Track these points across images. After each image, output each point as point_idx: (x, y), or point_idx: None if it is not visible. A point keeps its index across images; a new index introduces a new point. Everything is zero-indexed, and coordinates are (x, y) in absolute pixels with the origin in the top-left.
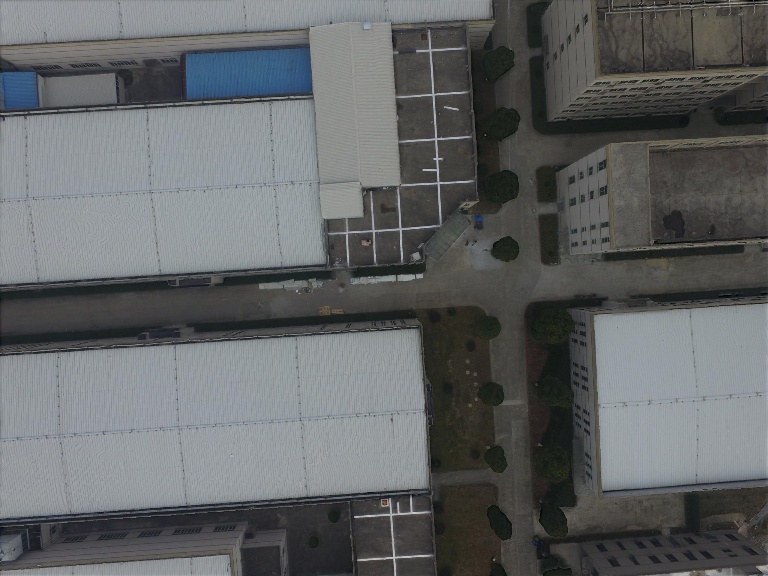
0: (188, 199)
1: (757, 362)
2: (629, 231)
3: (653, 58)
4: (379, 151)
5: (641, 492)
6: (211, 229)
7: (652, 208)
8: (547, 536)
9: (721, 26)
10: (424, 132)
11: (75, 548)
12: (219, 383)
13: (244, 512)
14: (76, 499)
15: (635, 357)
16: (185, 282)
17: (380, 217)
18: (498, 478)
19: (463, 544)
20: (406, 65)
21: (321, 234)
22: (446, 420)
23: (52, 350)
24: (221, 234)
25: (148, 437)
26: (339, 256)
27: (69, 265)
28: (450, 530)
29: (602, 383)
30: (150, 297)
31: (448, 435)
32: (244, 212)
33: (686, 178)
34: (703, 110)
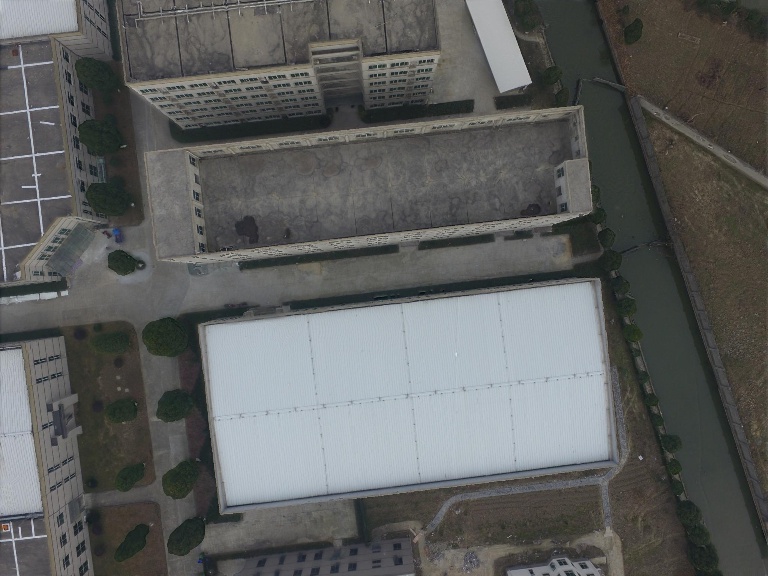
0: None
1: (379, 366)
2: (173, 241)
3: (191, 62)
4: None
5: (266, 505)
6: None
7: (223, 215)
8: (214, 553)
9: (260, 26)
10: (21, 149)
11: None
12: None
13: None
14: None
15: (251, 367)
16: None
17: None
18: (159, 495)
19: (125, 565)
20: None
21: None
22: (99, 438)
23: None
24: None
25: None
26: None
27: None
28: (112, 551)
29: (217, 395)
30: None
31: (102, 454)
32: None
33: (256, 182)
34: (345, 109)
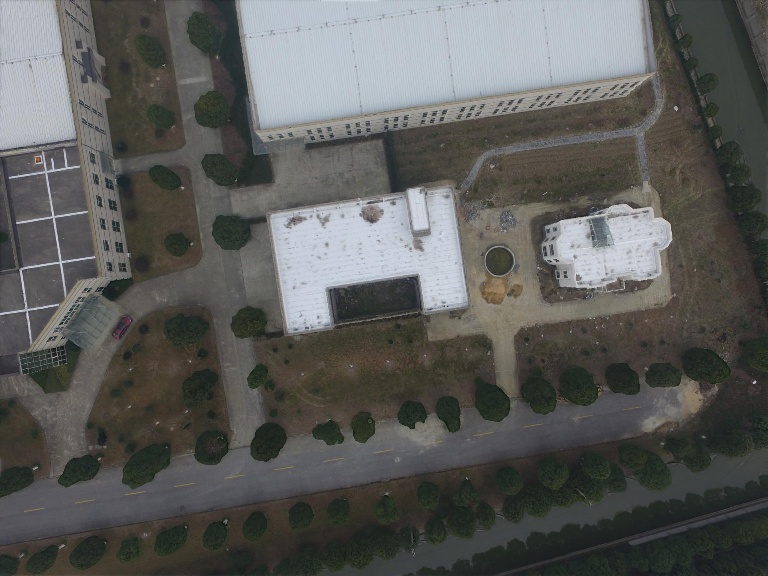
0: None
1: None
2: None
3: None
4: None
5: None
6: None
7: None
8: (247, 217)
9: None
10: None
11: None
12: None
13: None
14: None
15: None
16: None
17: None
18: (189, 160)
19: (157, 230)
20: None
21: None
22: (128, 102)
23: None
24: None
25: None
26: None
27: None
28: (143, 217)
29: (247, 13)
30: None
31: (131, 117)
32: None
33: None
34: None
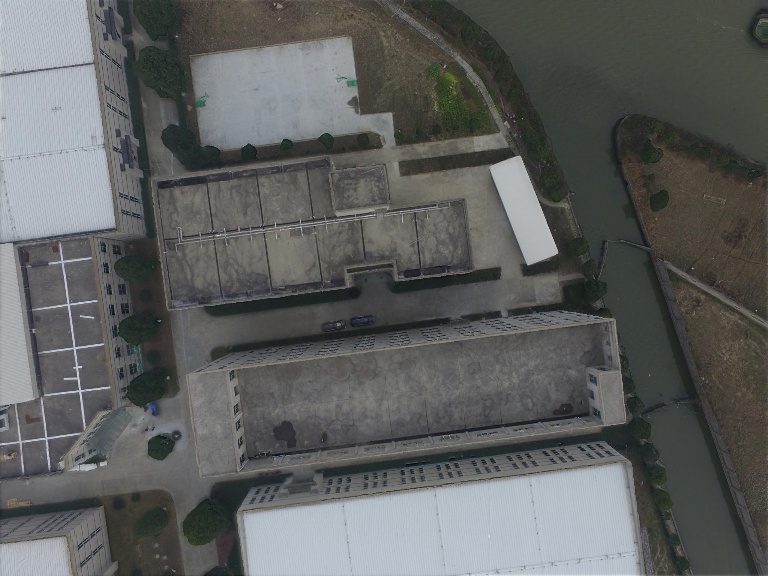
0: None
1: (414, 549)
2: (215, 459)
3: (230, 283)
4: (8, 370)
5: None
6: None
7: (261, 420)
8: None
9: (296, 246)
10: (62, 342)
11: None
12: None
13: None
14: None
15: (288, 551)
16: None
17: (26, 428)
18: None
19: None
20: (40, 278)
21: None
22: None
23: None
24: None
25: None
26: None
27: None
28: None
29: None
30: None
31: None
32: None
33: (293, 388)
34: (374, 280)
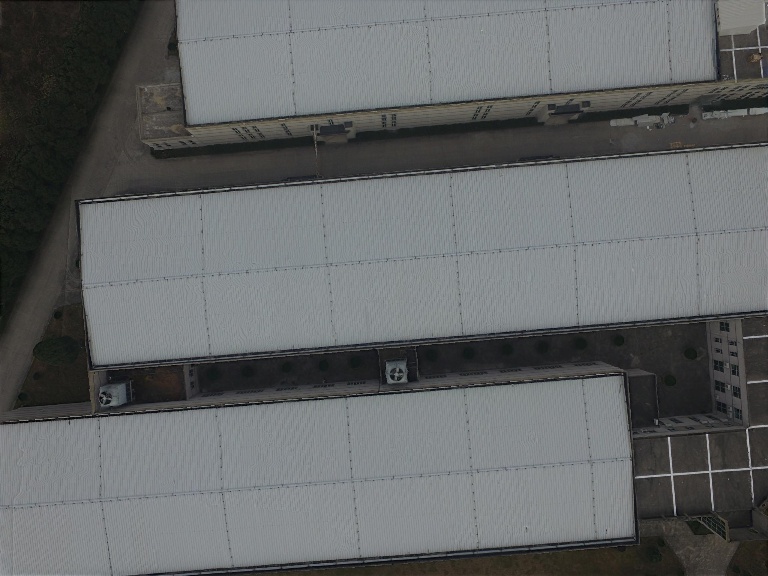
0: (582, 16)
1: None
2: None
3: None
4: None
5: None
6: (596, 50)
7: None
8: None
9: None
10: None
11: (449, 379)
12: (612, 200)
13: (597, 352)
14: (475, 316)
15: None
16: (559, 109)
17: (766, 33)
18: None
19: None
20: None
21: (712, 49)
22: None
23: (445, 170)
24: (606, 54)
25: (544, 254)
26: (726, 73)
27: (449, 92)
28: None
29: None
30: (502, 136)
31: None
32: (630, 32)
33: None
34: None
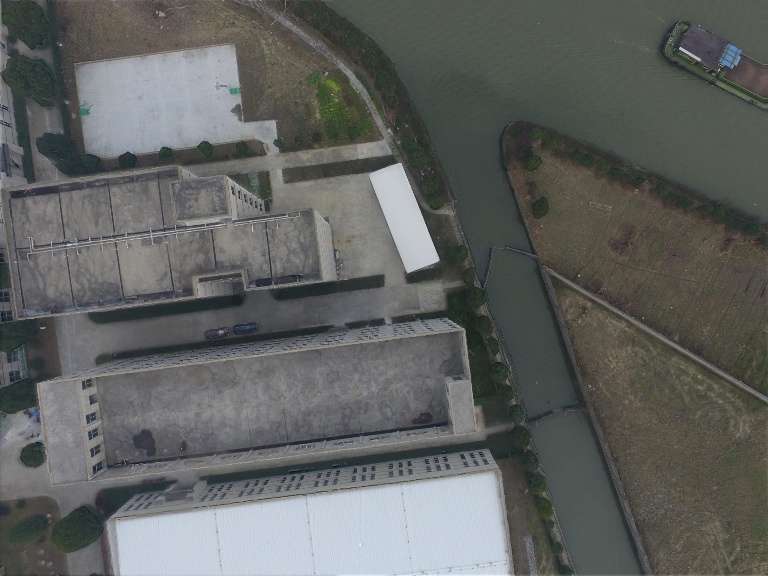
0: None
1: (285, 557)
2: (66, 467)
3: (82, 293)
4: None
5: None
6: None
7: (121, 429)
8: None
9: (148, 255)
10: None
11: None
12: None
13: None
14: None
15: (160, 559)
16: None
17: None
18: None
19: None
20: None
21: None
22: None
23: None
24: None
25: None
26: None
27: None
28: None
29: None
30: None
31: None
32: None
33: (153, 396)
34: None
